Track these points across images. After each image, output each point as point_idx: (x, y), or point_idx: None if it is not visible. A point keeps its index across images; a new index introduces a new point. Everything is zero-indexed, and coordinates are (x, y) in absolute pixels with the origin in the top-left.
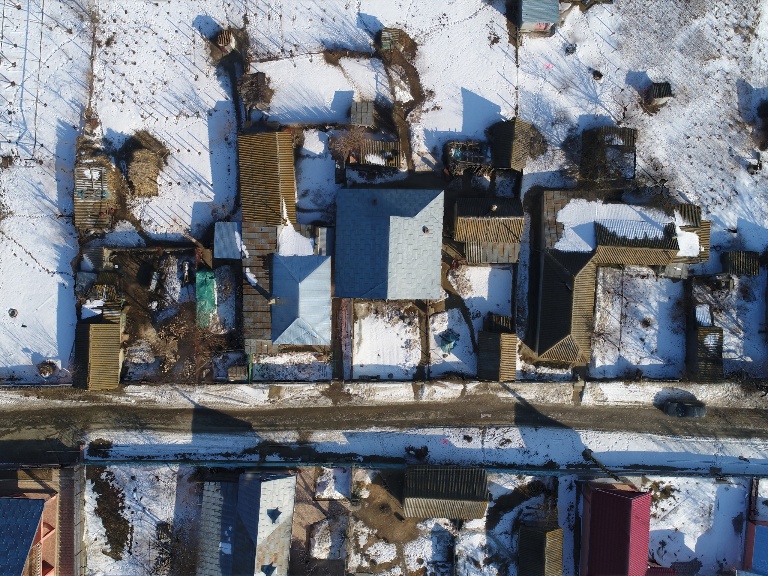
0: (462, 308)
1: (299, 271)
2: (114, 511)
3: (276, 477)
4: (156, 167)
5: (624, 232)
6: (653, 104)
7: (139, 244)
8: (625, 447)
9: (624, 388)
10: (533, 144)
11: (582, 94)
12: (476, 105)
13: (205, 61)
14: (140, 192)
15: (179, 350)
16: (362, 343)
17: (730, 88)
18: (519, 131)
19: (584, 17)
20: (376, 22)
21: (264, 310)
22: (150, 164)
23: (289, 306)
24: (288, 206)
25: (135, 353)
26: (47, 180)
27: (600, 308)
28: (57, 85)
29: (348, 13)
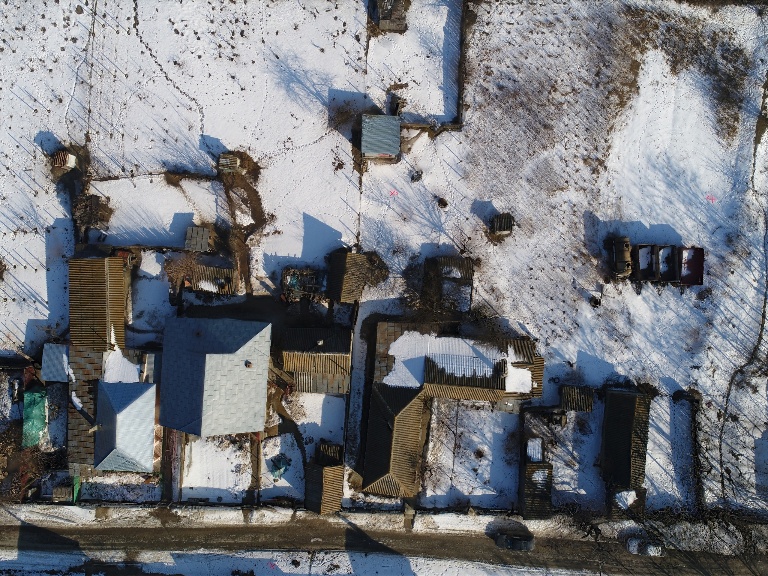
0: (295, 433)
1: (120, 401)
2: None
3: None
4: None
5: (453, 369)
6: (498, 234)
7: None
8: (455, 575)
9: (455, 517)
10: (374, 271)
11: (426, 222)
12: (317, 231)
13: (45, 177)
14: None
15: (8, 466)
16: (192, 466)
17: (577, 220)
18: (352, 264)
19: (432, 144)
20: (219, 144)
21: (88, 435)
22: None
23: (109, 435)
24: (117, 331)
25: None
26: None
27: (433, 438)
28: None
29: (191, 134)
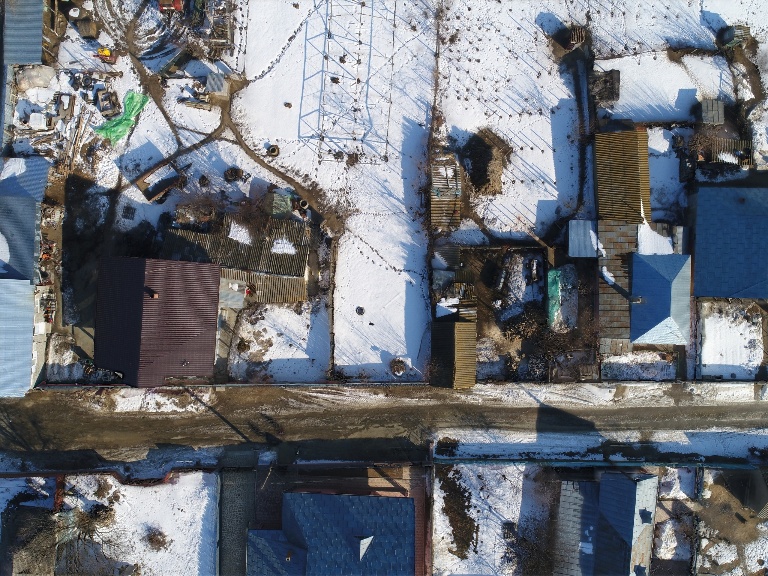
0: None
1: (666, 270)
2: (460, 510)
3: (643, 477)
4: (502, 165)
5: None
6: None
7: (484, 242)
8: None
9: None
10: None
11: None
12: None
13: (547, 58)
14: (487, 190)
15: (523, 349)
16: (706, 343)
17: None
18: None
19: None
20: (719, 19)
21: (622, 309)
22: (501, 162)
23: (656, 305)
24: (644, 205)
25: (481, 352)
26: (393, 178)
27: None
28: (402, 82)
29: (691, 10)
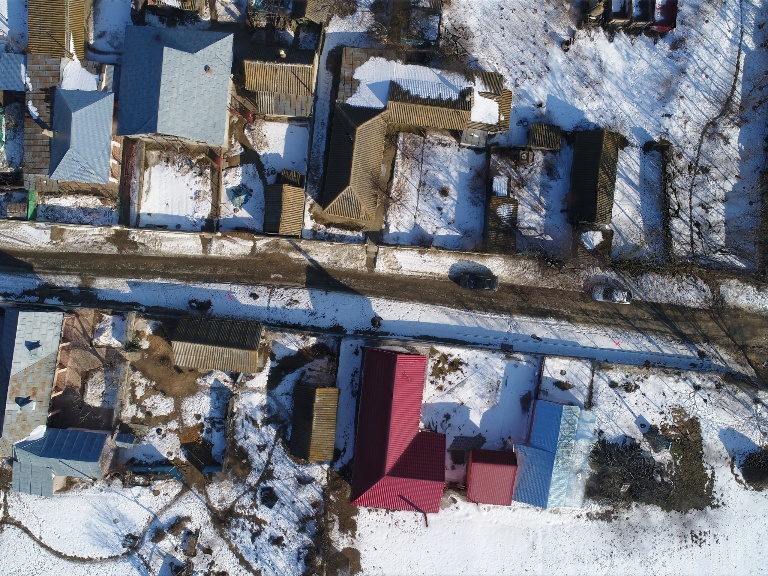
0: (257, 164)
1: (76, 103)
2: None
3: (39, 310)
4: None
5: (418, 91)
6: None
7: None
8: (417, 317)
9: (418, 257)
10: (342, 3)
11: None
12: None
13: None
14: None
15: None
16: (151, 191)
17: None
18: None
19: None
20: None
21: (44, 144)
22: None
23: (64, 138)
24: (76, 41)
25: None
26: None
27: (397, 173)
28: None
29: None
